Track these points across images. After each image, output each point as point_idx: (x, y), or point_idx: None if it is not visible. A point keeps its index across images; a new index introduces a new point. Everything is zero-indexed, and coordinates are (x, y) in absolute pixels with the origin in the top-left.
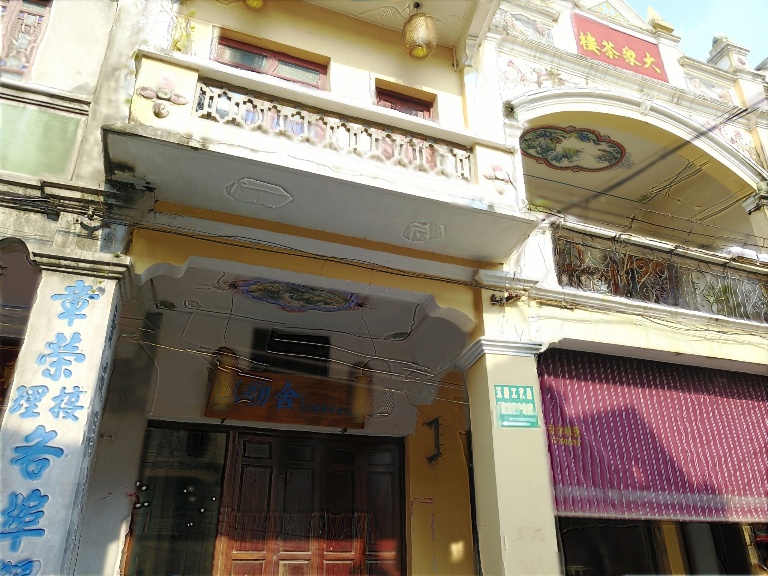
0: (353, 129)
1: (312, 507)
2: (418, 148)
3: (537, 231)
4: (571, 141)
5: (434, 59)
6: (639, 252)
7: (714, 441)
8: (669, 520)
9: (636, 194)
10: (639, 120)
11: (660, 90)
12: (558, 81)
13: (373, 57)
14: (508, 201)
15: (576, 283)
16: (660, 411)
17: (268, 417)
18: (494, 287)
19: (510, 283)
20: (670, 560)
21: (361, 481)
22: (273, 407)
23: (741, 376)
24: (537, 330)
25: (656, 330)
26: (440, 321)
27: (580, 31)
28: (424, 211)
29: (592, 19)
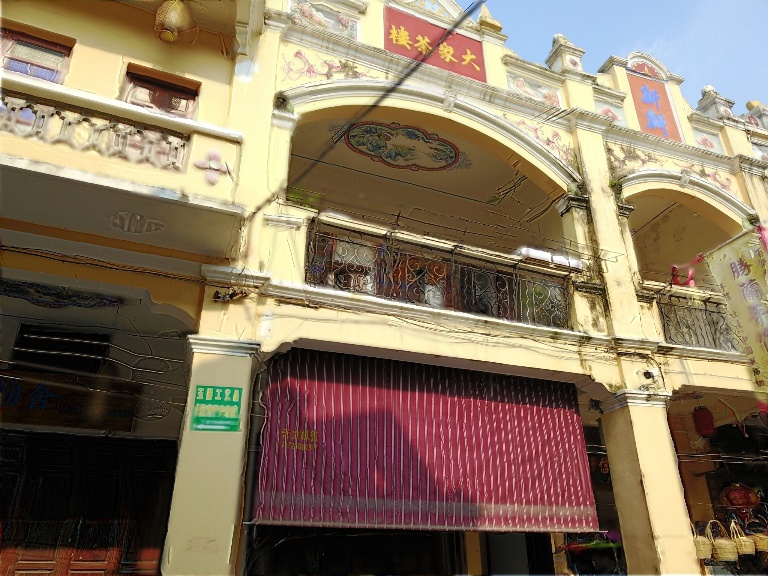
0: (42, 111)
1: (67, 513)
2: (123, 134)
3: (287, 226)
4: (400, 138)
5: (201, 45)
6: (415, 251)
7: (478, 447)
8: (407, 529)
9: (483, 195)
10: (442, 117)
11: (470, 87)
12: (352, 74)
13: (130, 41)
14: (219, 192)
15: (333, 281)
16: (420, 415)
17: (18, 418)
18: (218, 283)
19: (236, 279)
20: (468, 569)
21: (126, 486)
22: (24, 407)
23: (524, 380)
24: (269, 329)
25: (413, 331)
26: (171, 318)
27: (392, 25)
28: (105, 199)
29: (409, 13)
